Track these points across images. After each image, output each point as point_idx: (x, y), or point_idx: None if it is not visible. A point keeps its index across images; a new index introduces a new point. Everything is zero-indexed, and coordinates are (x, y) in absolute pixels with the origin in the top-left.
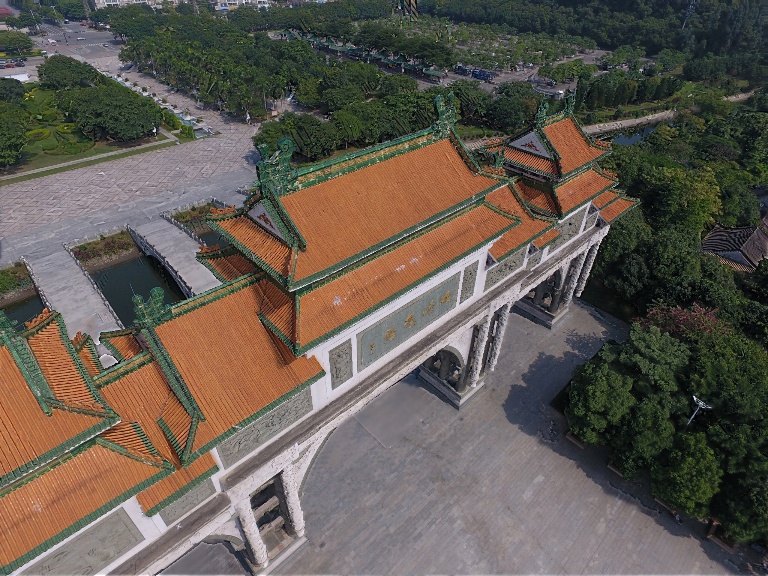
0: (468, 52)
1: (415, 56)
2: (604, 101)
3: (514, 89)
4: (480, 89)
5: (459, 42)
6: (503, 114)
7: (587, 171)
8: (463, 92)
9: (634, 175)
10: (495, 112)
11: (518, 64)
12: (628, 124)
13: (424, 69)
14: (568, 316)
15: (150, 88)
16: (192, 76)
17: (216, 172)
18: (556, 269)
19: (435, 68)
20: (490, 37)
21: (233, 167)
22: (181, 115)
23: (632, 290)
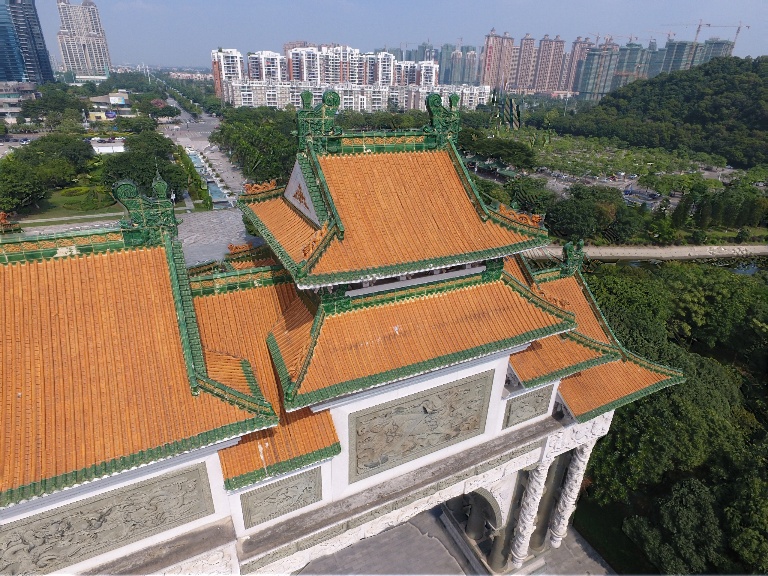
0: (561, 159)
1: (491, 155)
2: (721, 219)
3: (588, 191)
4: (543, 188)
5: (556, 150)
6: (567, 218)
7: (484, 282)
8: (520, 189)
9: (738, 319)
10: (556, 215)
11: (617, 173)
12: (757, 251)
13: (498, 169)
14: (542, 575)
15: (218, 165)
16: (246, 154)
17: (196, 243)
18: (420, 508)
19: (511, 168)
20: (593, 147)
21: (218, 240)
22: (221, 188)
23: (678, 568)
